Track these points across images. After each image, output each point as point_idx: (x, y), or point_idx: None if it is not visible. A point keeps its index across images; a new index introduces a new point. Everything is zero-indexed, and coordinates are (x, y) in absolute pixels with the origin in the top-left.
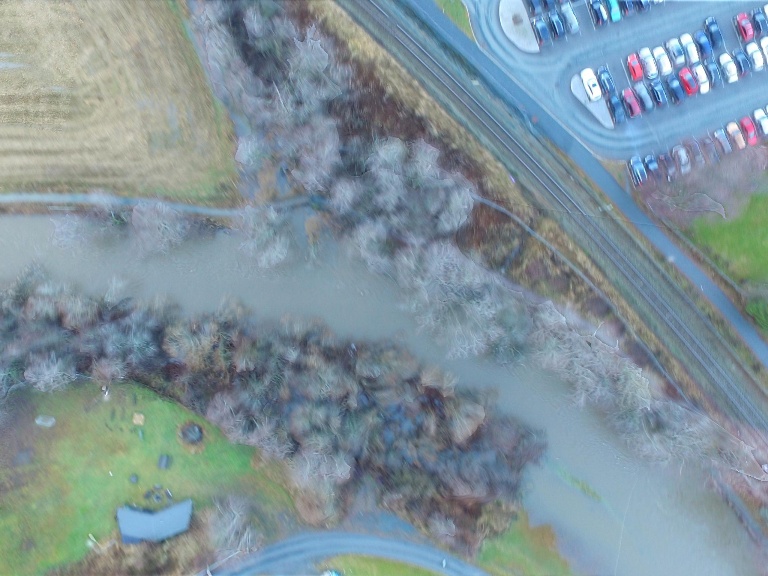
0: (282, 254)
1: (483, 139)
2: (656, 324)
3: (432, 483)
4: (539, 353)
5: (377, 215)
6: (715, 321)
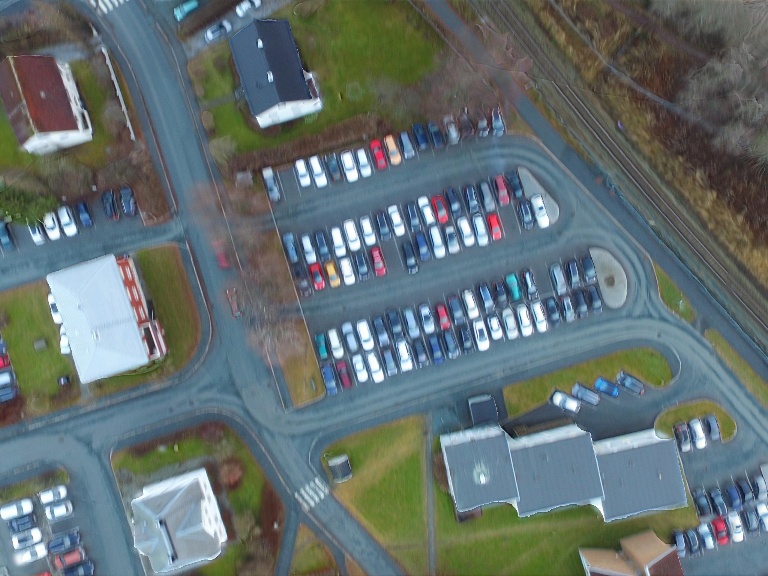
0: None
1: (647, 167)
2: None
3: None
4: None
5: None
6: None
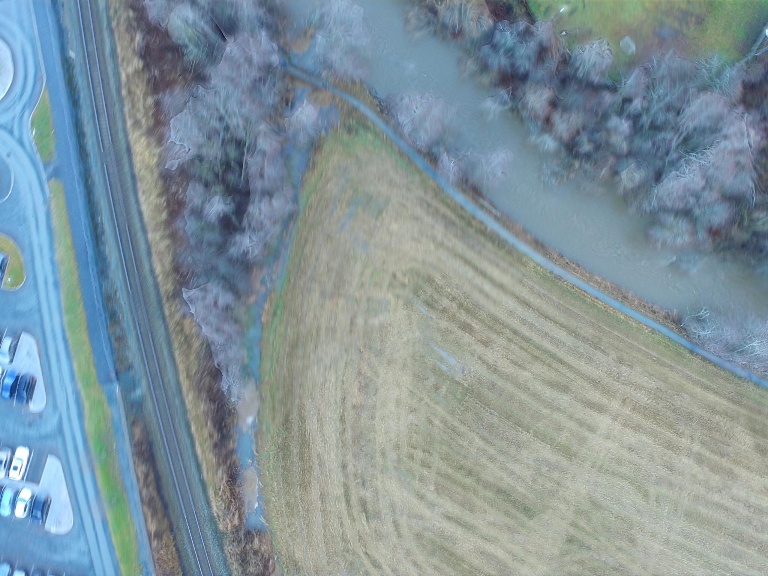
0: None
1: (103, 5)
2: None
3: None
4: None
5: None
6: None
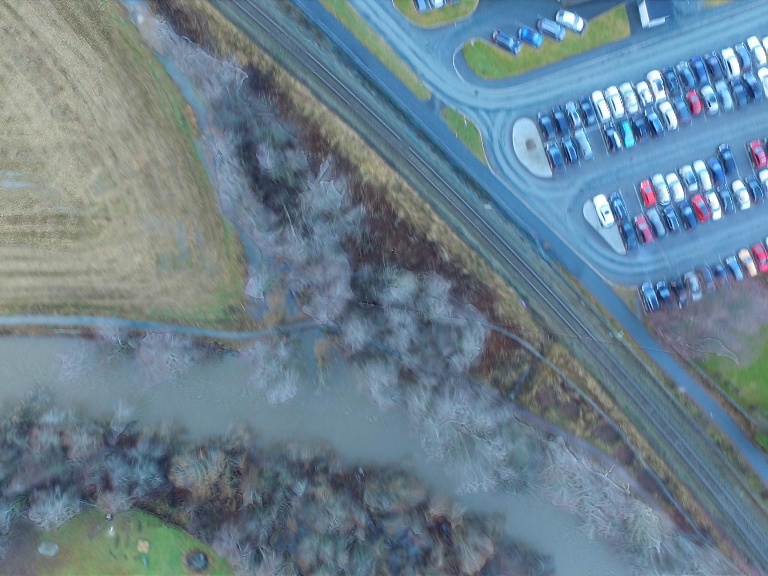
0: (292, 393)
1: (494, 263)
2: (665, 450)
3: None
4: (549, 488)
5: (388, 355)
6: (724, 448)
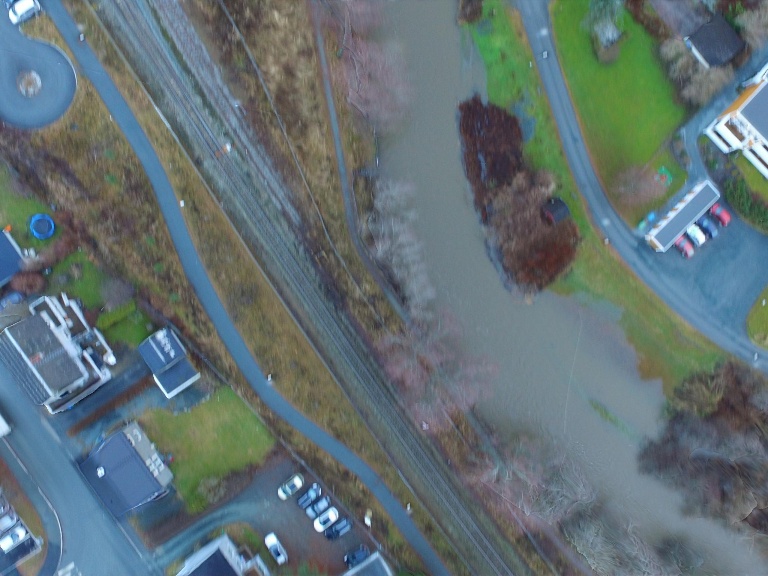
0: None
1: None
2: None
3: (767, 440)
4: None
5: None
6: None
